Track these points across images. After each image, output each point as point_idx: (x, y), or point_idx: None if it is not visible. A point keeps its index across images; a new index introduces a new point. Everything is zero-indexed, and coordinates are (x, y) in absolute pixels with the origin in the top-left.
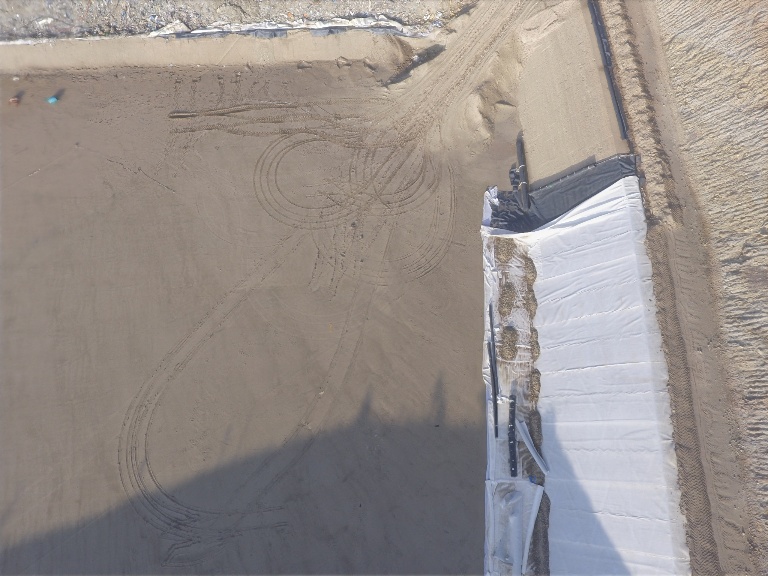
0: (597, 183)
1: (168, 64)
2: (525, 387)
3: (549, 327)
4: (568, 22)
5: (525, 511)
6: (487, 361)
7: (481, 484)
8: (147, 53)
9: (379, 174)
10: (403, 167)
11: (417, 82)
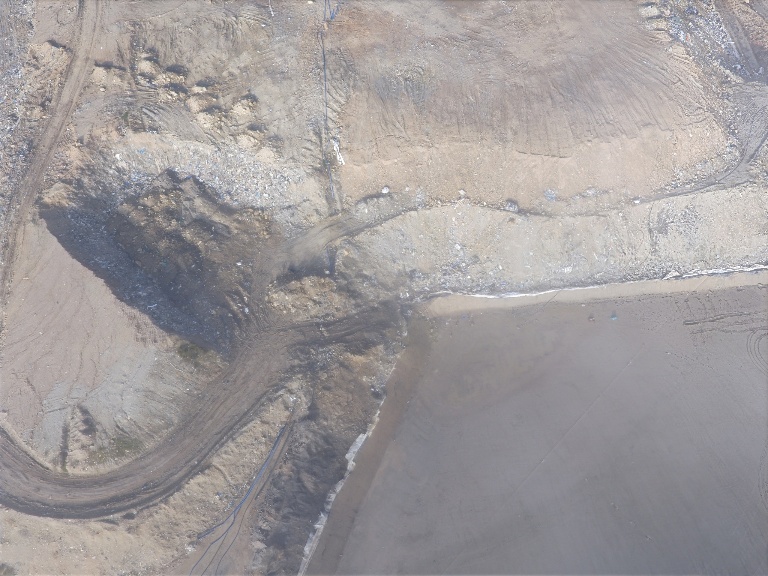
0: None
1: (667, 292)
2: None
3: None
4: None
5: None
6: None
7: None
8: (657, 287)
9: None
10: None
11: None
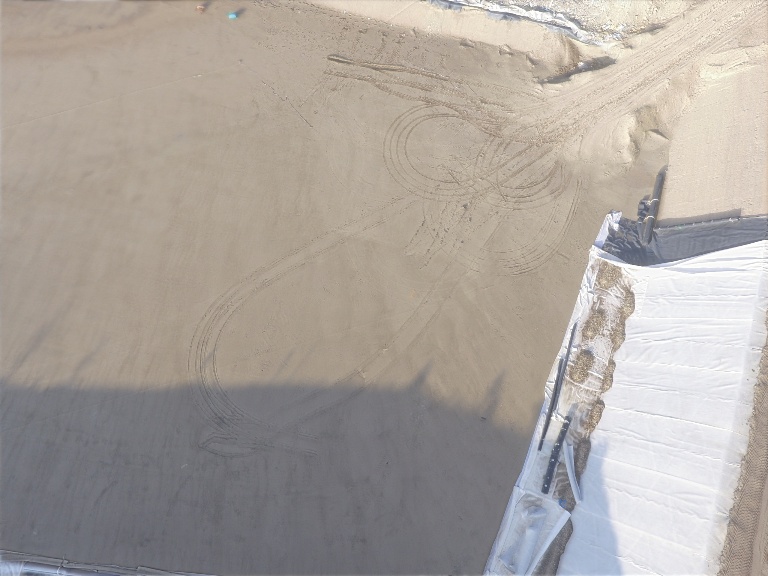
0: (734, 237)
1: (342, 10)
2: (584, 414)
3: (630, 364)
4: (759, 67)
5: (544, 529)
6: (554, 376)
7: (509, 488)
8: None
9: (506, 166)
10: (532, 166)
11: (574, 88)
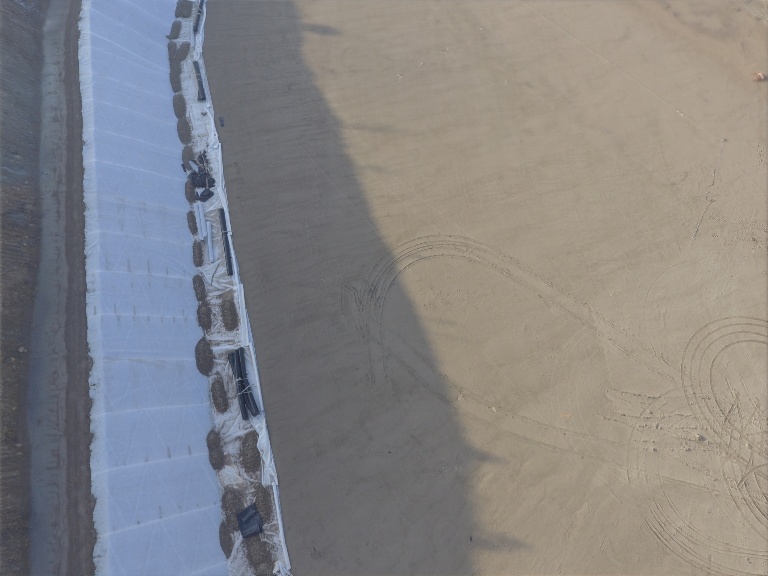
0: None
1: None
2: None
3: None
4: None
5: None
6: None
7: None
8: None
9: None
10: None
11: None
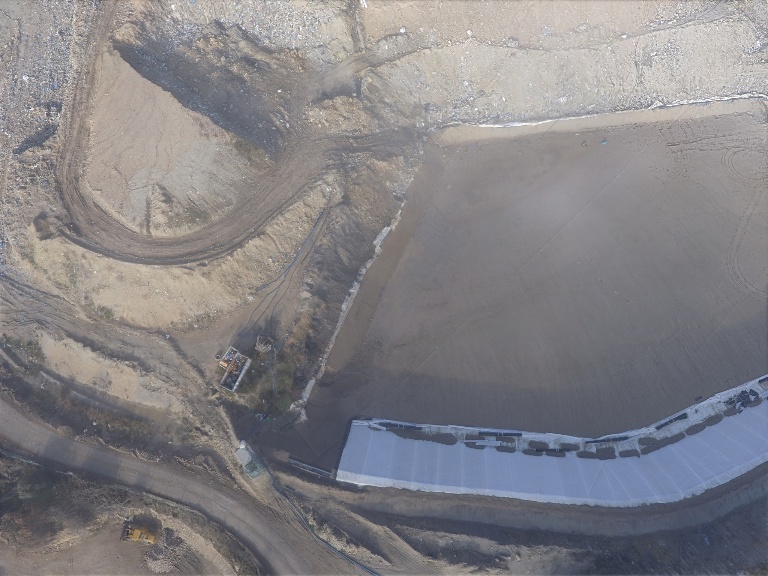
0: None
1: (652, 121)
2: None
3: None
4: None
5: None
6: None
7: None
8: (643, 117)
9: None
10: None
11: None
